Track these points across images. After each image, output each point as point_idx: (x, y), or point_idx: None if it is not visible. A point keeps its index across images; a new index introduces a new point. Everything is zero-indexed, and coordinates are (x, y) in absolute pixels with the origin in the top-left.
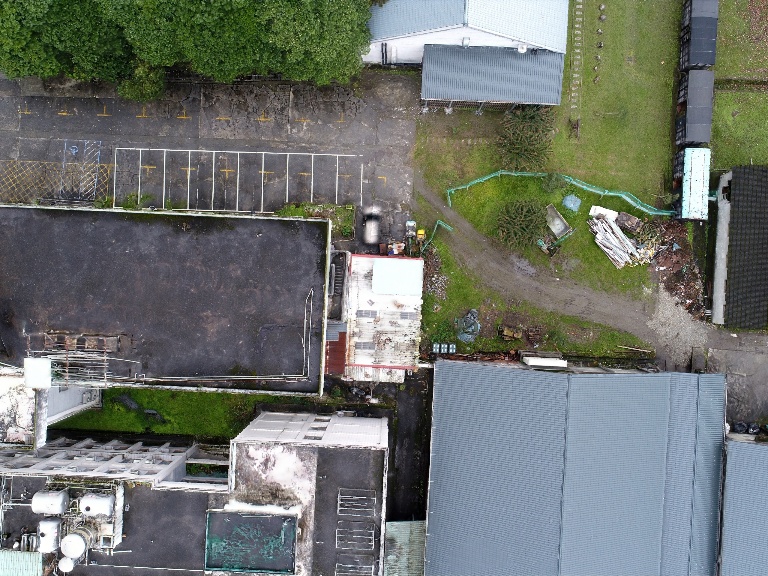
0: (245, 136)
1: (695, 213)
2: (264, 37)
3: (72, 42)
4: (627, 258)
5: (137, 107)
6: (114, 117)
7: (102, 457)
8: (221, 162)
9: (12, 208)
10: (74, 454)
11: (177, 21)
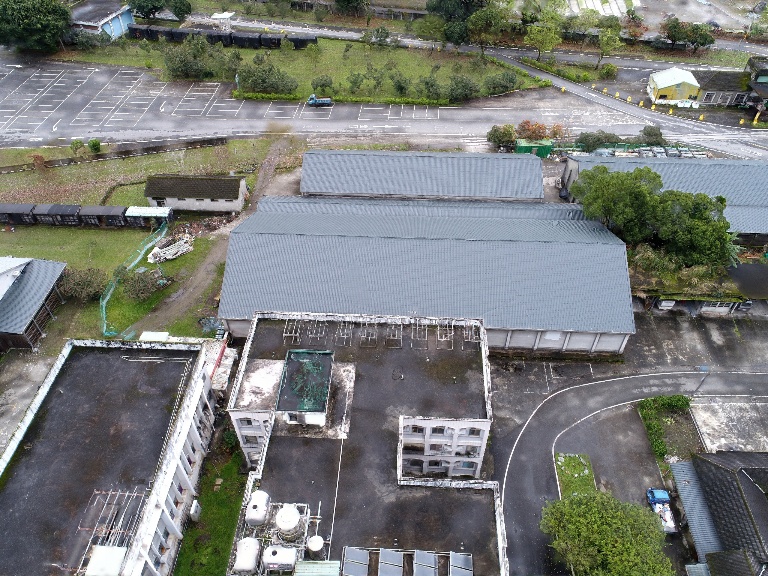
0: None
1: (166, 211)
2: None
3: None
4: (187, 245)
5: None
6: None
7: None
8: None
9: None
10: None
11: None
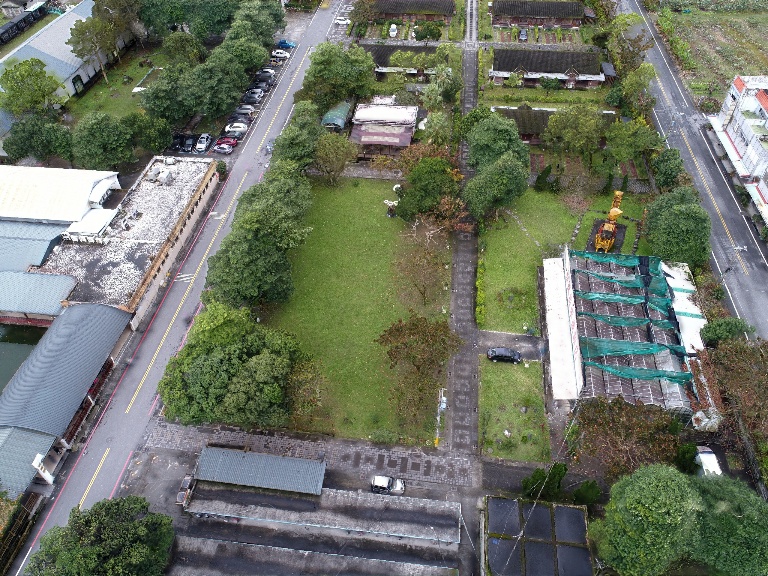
0: None
1: (40, 2)
2: None
3: None
4: None
5: None
6: None
7: None
8: None
9: None
10: None
11: None
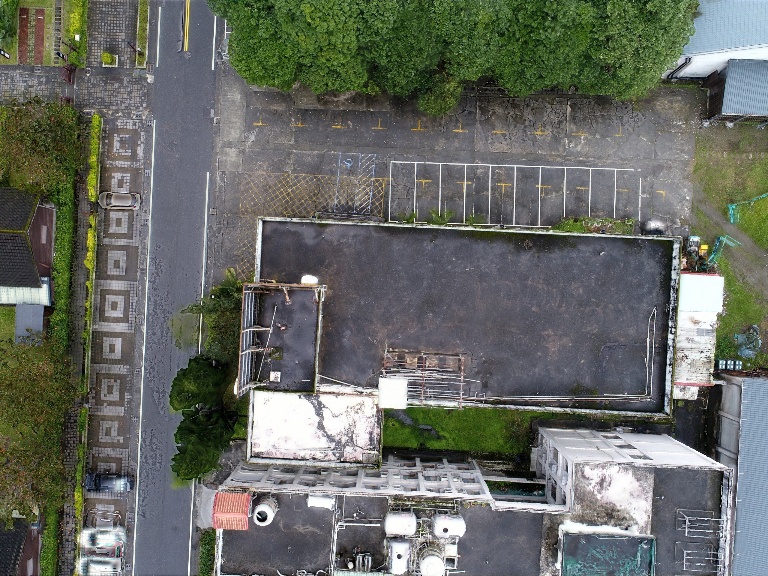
0: (522, 150)
1: None
2: (595, 53)
3: (399, 57)
4: None
5: (412, 120)
6: (389, 130)
7: (401, 474)
8: (497, 176)
9: (351, 225)
10: (373, 471)
11: (509, 36)
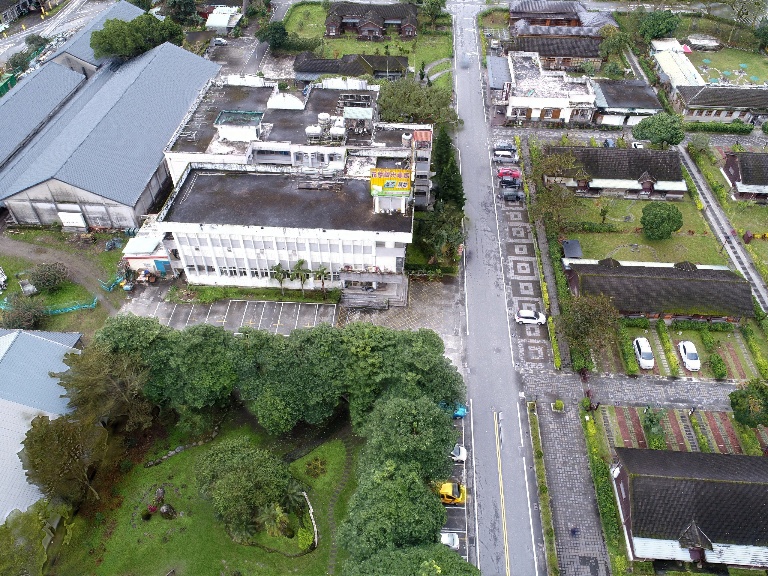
0: None
1: None
2: (171, 329)
3: None
4: None
5: None
6: None
7: None
8: None
9: None
10: None
11: None
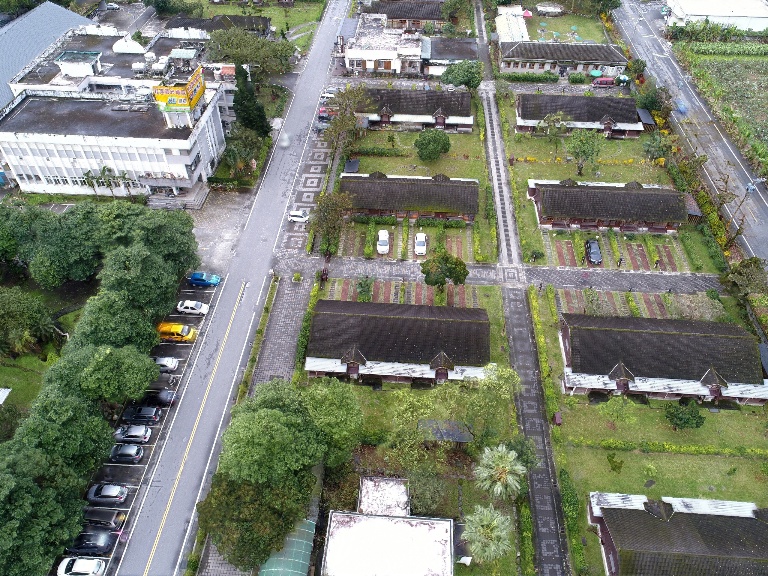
0: None
1: None
2: None
3: None
4: None
5: None
6: None
7: None
8: None
9: None
10: None
11: None
